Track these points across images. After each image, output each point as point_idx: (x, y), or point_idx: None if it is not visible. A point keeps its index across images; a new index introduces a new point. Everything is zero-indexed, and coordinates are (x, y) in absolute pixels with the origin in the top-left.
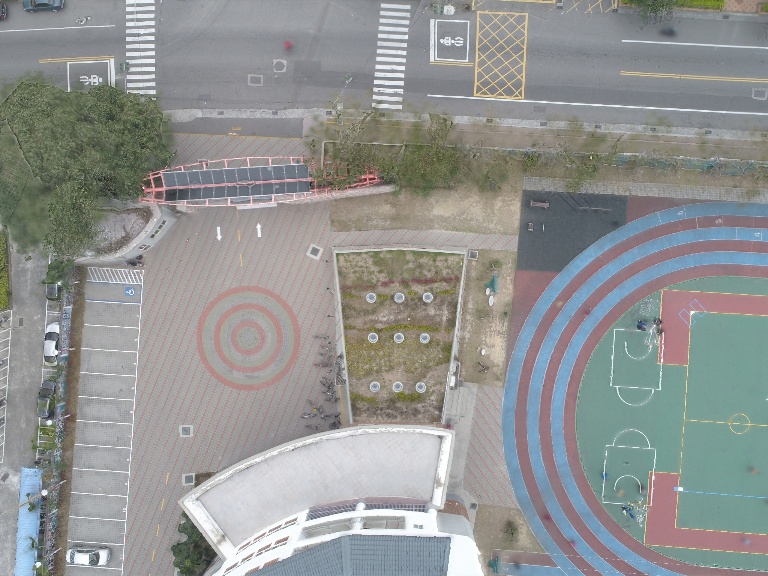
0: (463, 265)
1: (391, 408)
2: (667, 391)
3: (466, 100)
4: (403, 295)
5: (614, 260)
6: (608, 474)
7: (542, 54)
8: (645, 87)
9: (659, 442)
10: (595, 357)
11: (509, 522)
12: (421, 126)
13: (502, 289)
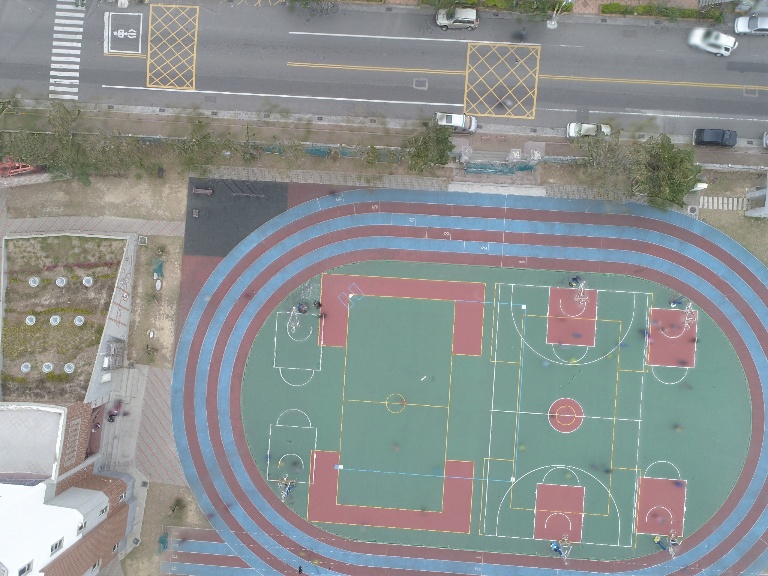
0: (124, 250)
1: (39, 388)
2: (327, 372)
3: (139, 90)
4: (64, 279)
5: (276, 245)
6: (272, 453)
7: (212, 46)
8: (311, 77)
9: (320, 421)
10: (259, 339)
11: (178, 499)
12: (96, 116)
13: (170, 274)
